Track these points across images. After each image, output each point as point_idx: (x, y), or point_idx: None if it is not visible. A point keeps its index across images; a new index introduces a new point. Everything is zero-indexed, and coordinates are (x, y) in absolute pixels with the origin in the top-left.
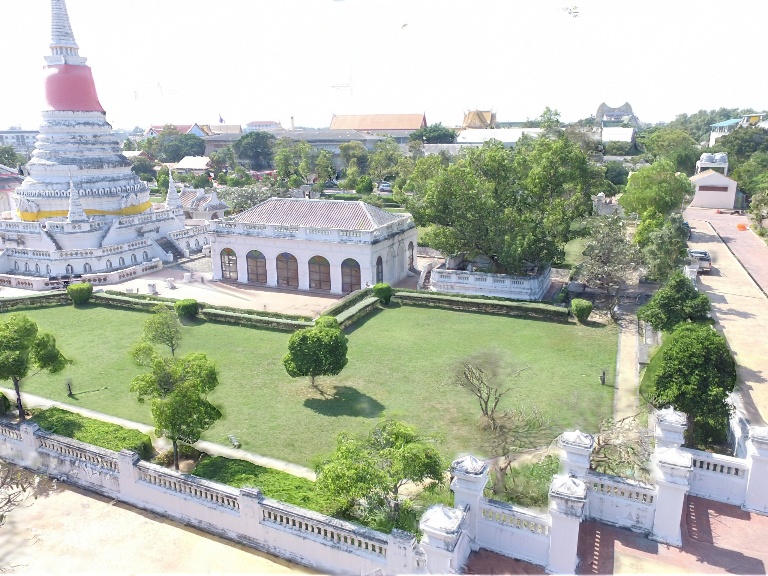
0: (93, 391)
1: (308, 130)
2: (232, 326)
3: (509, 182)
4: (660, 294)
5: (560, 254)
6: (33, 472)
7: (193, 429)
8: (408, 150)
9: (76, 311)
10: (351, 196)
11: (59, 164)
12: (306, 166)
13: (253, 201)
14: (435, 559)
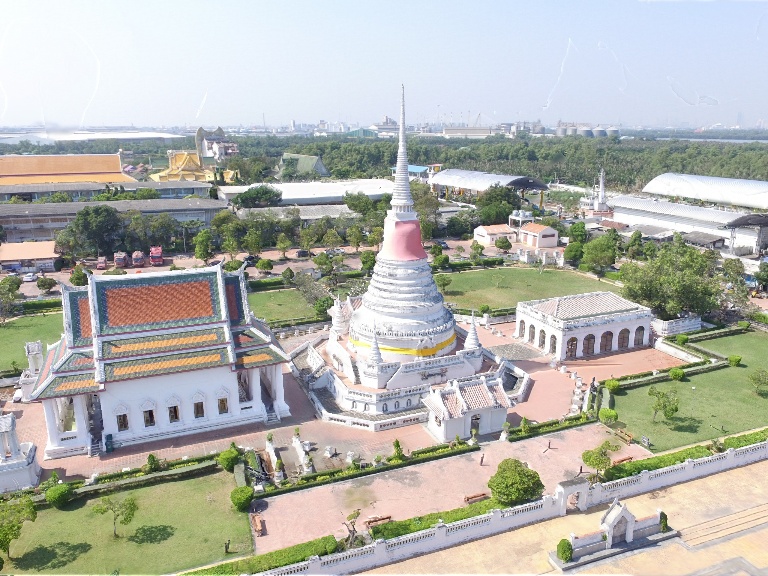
0: None
1: (25, 184)
2: (698, 375)
3: None
4: None
5: None
6: None
7: None
8: (284, 216)
9: None
10: (358, 273)
11: (436, 303)
12: (237, 245)
13: None
14: None
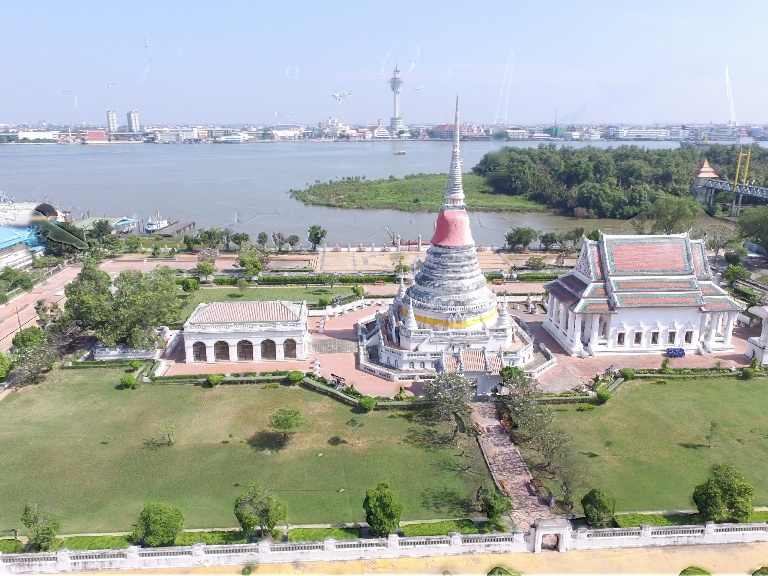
0: (253, 290)
1: None
2: None
3: None
4: None
5: None
6: None
7: None
8: None
9: None
10: None
11: None
12: None
13: None
14: None
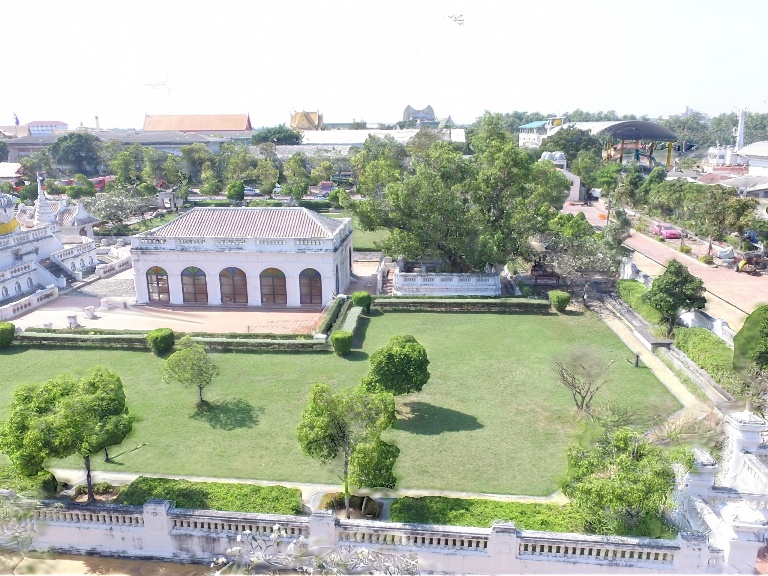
0: (131, 451)
1: None
2: (224, 354)
3: (466, 183)
4: (664, 280)
5: (516, 250)
6: (168, 561)
7: (390, 472)
8: (259, 152)
9: (3, 358)
10: (221, 202)
11: None
12: (152, 171)
13: (124, 212)
14: (741, 553)
